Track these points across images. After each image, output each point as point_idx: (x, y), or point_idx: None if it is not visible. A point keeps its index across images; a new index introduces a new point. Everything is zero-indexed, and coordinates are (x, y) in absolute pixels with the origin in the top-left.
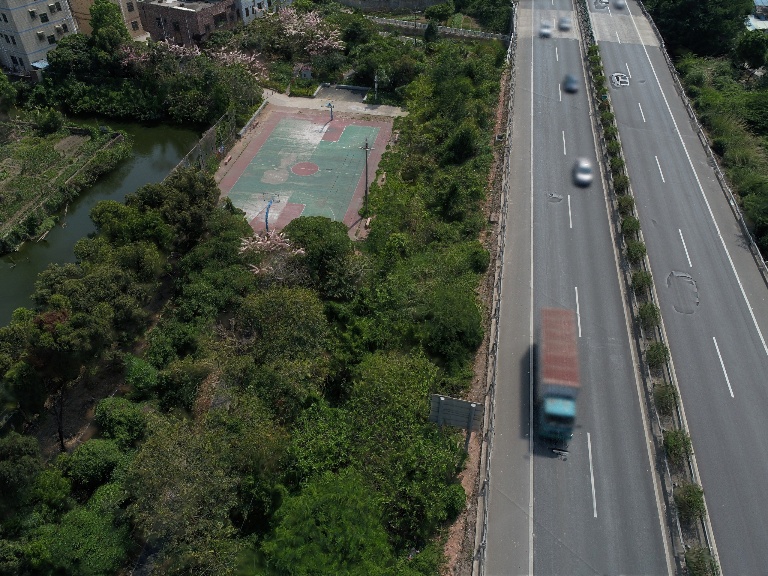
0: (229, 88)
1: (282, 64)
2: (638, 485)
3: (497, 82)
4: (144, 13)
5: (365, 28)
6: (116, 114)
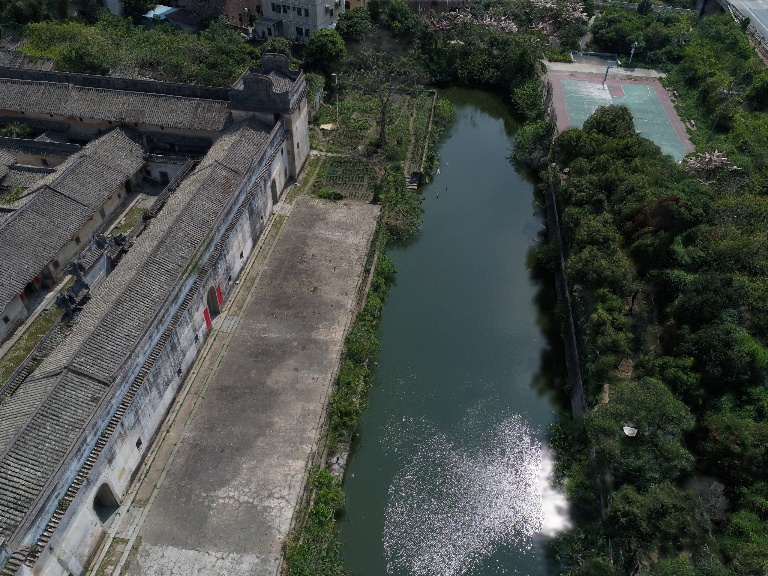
0: None
1: None
2: None
3: (753, 45)
4: None
5: (592, 2)
6: (410, 77)
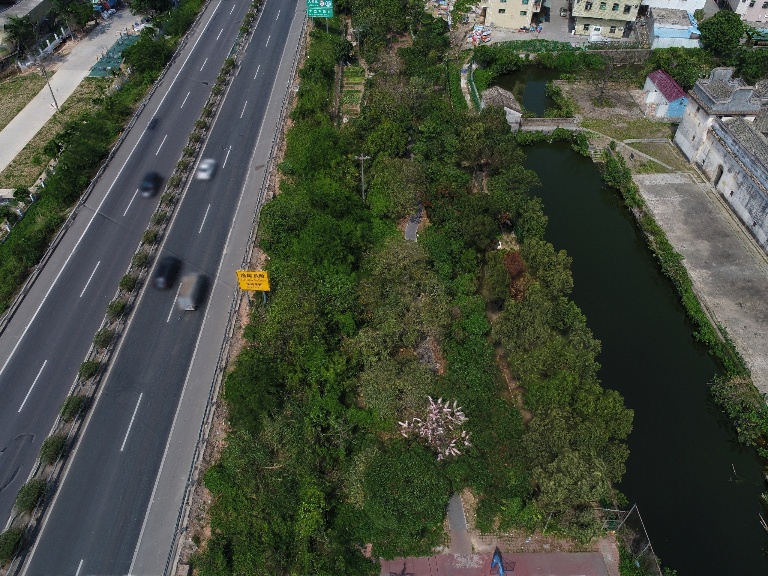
0: None
1: None
2: (150, 298)
3: None
4: None
5: None
6: None
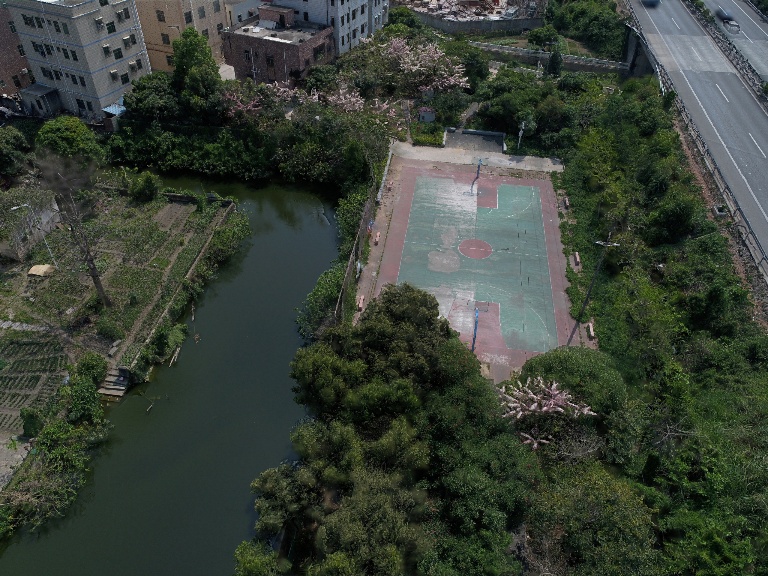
0: (363, 144)
1: (388, 102)
2: None
3: None
4: (229, 44)
5: (483, 60)
6: (215, 172)
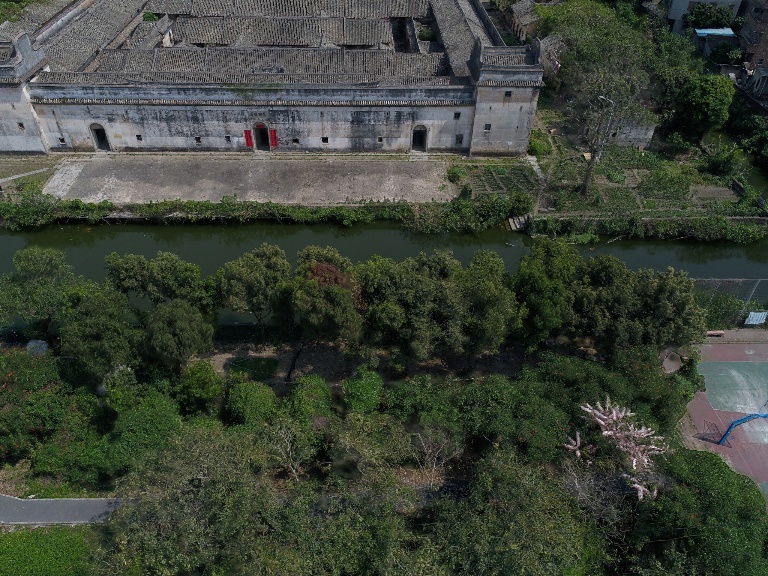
0: None
1: None
2: None
3: None
4: None
5: None
6: None
